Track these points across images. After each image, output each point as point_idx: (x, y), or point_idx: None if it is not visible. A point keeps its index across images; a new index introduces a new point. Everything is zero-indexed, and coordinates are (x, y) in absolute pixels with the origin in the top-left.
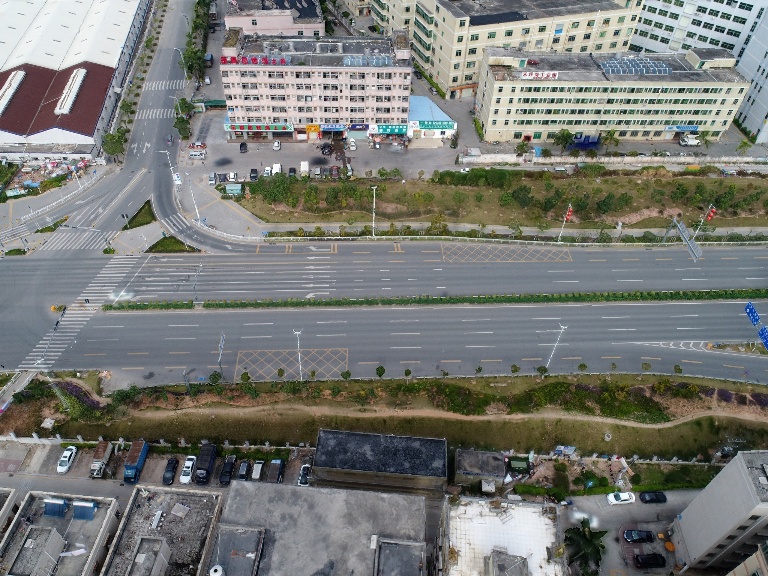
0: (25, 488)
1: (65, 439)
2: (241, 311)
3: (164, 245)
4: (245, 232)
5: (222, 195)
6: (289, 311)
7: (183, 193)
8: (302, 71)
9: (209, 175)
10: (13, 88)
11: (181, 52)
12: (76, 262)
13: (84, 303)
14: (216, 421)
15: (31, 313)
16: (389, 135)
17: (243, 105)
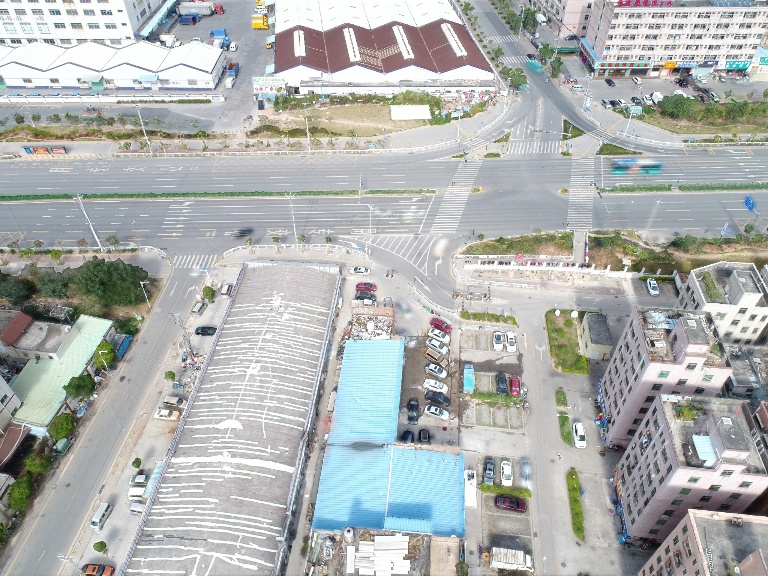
0: (634, 304)
1: (644, 273)
2: (711, 193)
3: (608, 149)
4: (666, 140)
5: (627, 115)
6: (750, 193)
7: (589, 115)
8: (682, 12)
9: (602, 101)
10: (405, 38)
11: (523, 9)
12: (546, 161)
13: (579, 188)
14: (759, 261)
15: (543, 195)
16: (729, 71)
17: (619, 44)
